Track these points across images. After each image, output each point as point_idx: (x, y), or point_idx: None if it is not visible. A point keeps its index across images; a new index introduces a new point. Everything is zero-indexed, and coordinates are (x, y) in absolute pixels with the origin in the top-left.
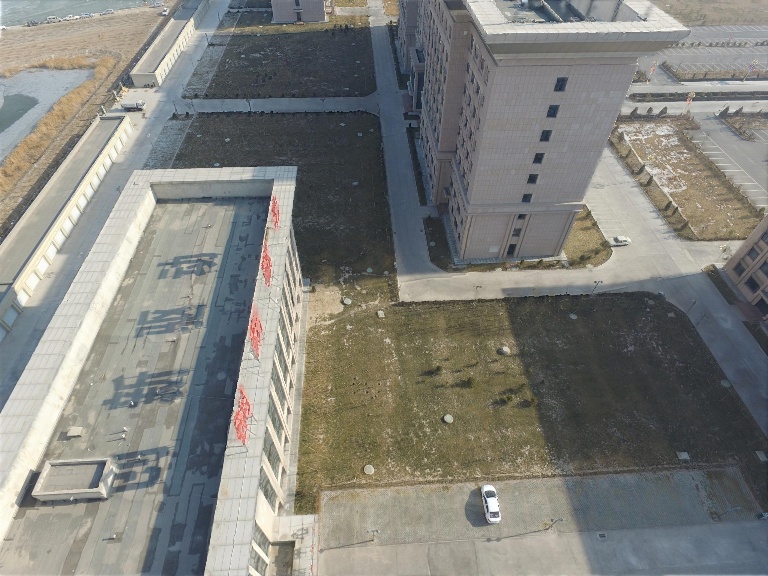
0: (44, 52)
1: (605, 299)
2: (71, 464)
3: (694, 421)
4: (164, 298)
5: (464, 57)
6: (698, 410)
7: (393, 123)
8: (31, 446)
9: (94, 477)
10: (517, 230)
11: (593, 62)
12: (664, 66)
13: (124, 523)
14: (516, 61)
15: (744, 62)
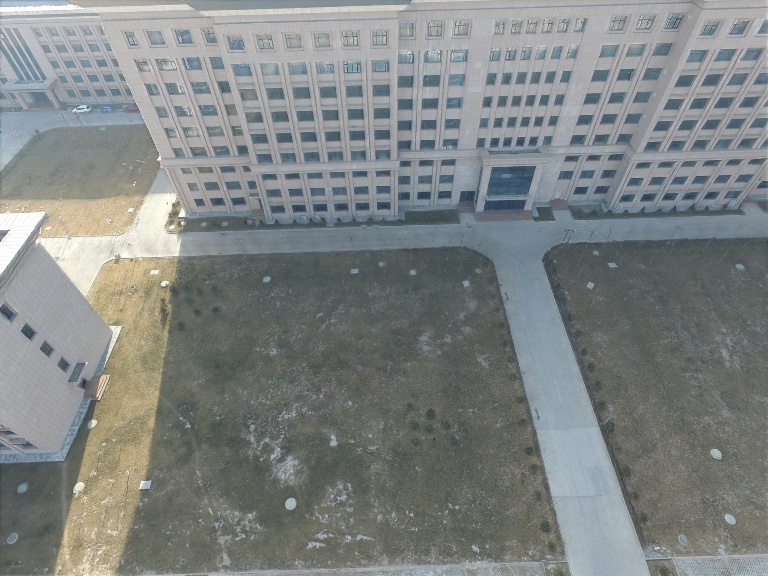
0: None
1: None
2: None
3: None
4: None
5: None
6: None
7: None
8: None
9: None
10: None
11: None
12: None
13: None
14: None
15: None
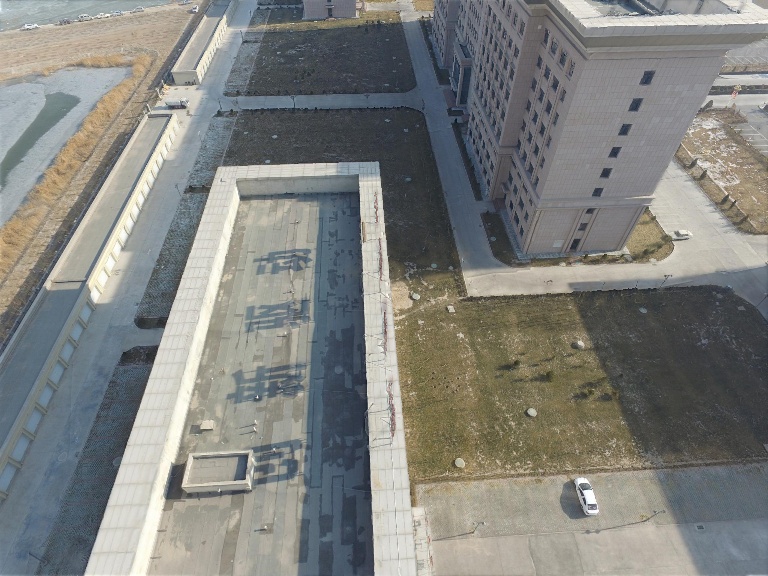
0: (80, 50)
1: (673, 293)
2: (213, 457)
3: None
4: (267, 293)
5: (535, 51)
6: None
7: (438, 119)
8: (171, 439)
9: (238, 469)
10: (583, 224)
11: (682, 55)
12: None
13: (272, 514)
14: (606, 55)
15: None
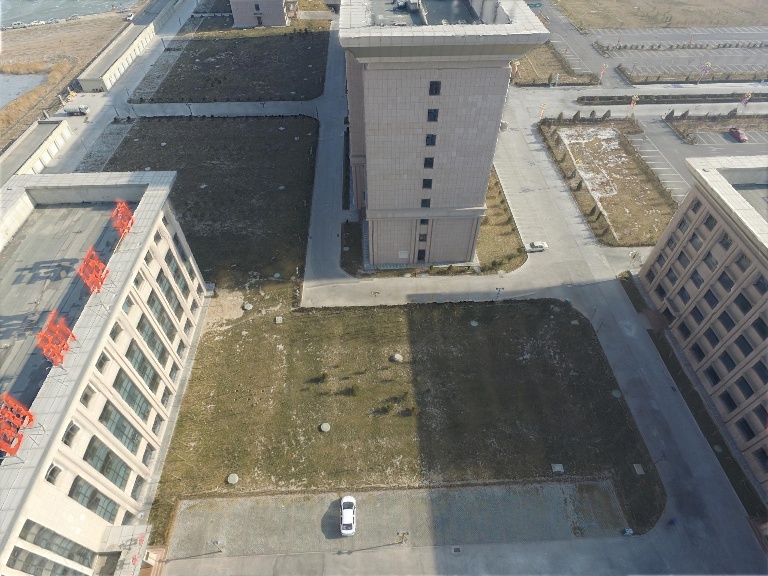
0: (3, 57)
1: (510, 306)
2: None
3: (577, 432)
4: (11, 304)
5: None
6: (583, 421)
7: (332, 127)
8: None
9: None
10: (423, 235)
11: (464, 65)
12: (619, 69)
13: None
14: (383, 65)
15: (702, 64)
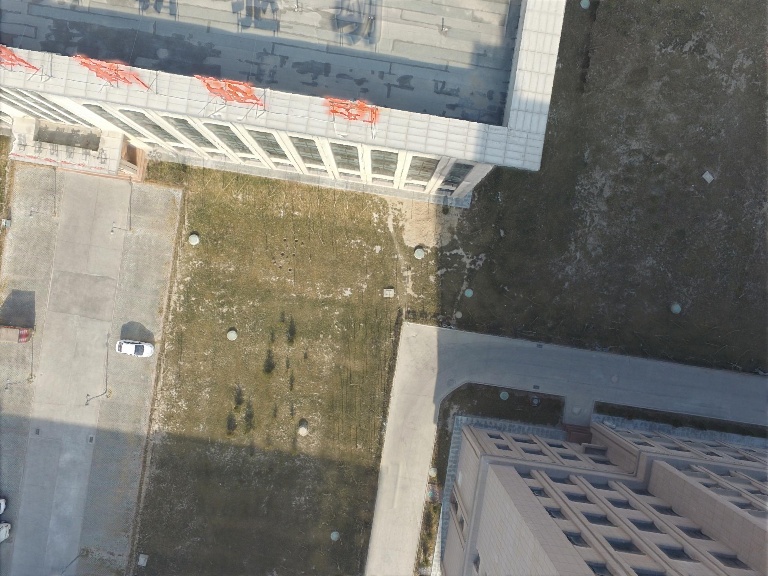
0: None
1: None
2: None
3: None
4: None
5: None
6: None
7: None
8: None
9: None
10: None
11: None
12: None
13: None
14: None
15: None
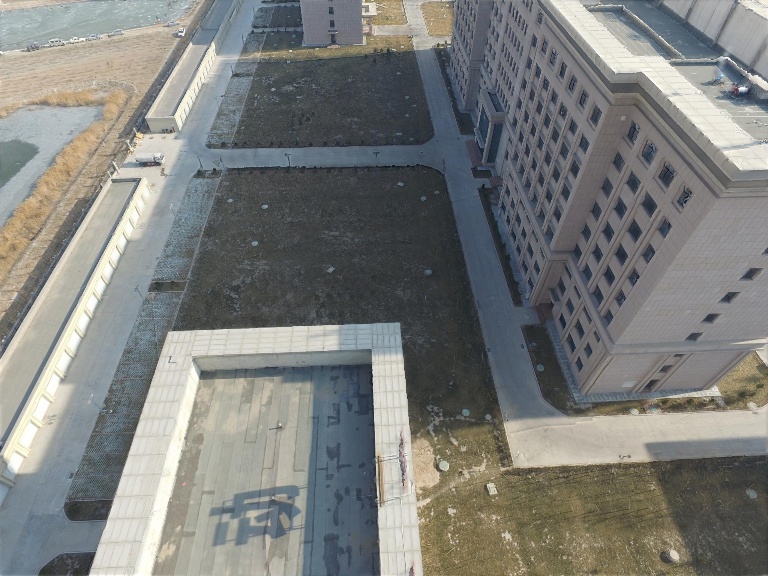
0: (45, 85)
1: None
2: None
3: None
4: None
5: (613, 147)
6: None
7: (461, 182)
8: None
9: None
10: (665, 366)
11: None
12: None
13: None
14: None
15: None
